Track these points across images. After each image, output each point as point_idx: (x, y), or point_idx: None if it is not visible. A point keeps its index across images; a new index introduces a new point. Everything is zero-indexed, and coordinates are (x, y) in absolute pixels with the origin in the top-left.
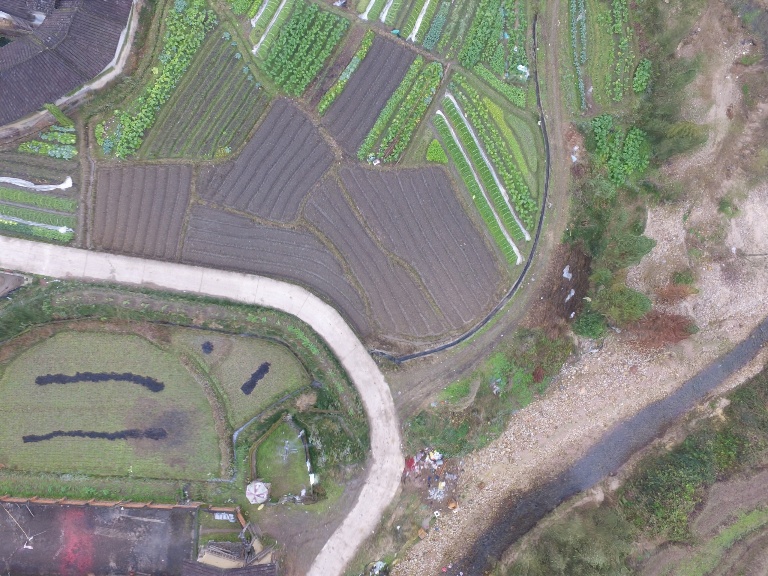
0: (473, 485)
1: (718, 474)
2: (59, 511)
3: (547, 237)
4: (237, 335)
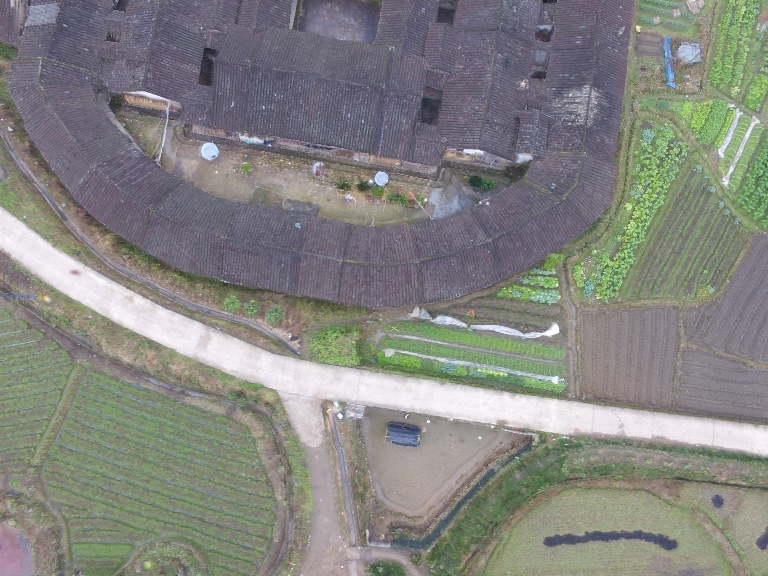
0: None
1: None
2: None
3: None
4: (752, 489)
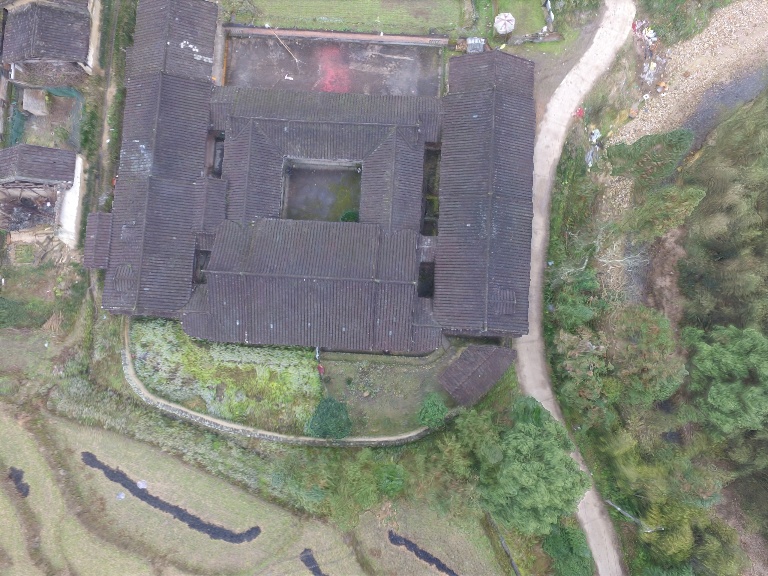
0: (678, 74)
1: None
2: (316, 49)
3: None
4: None
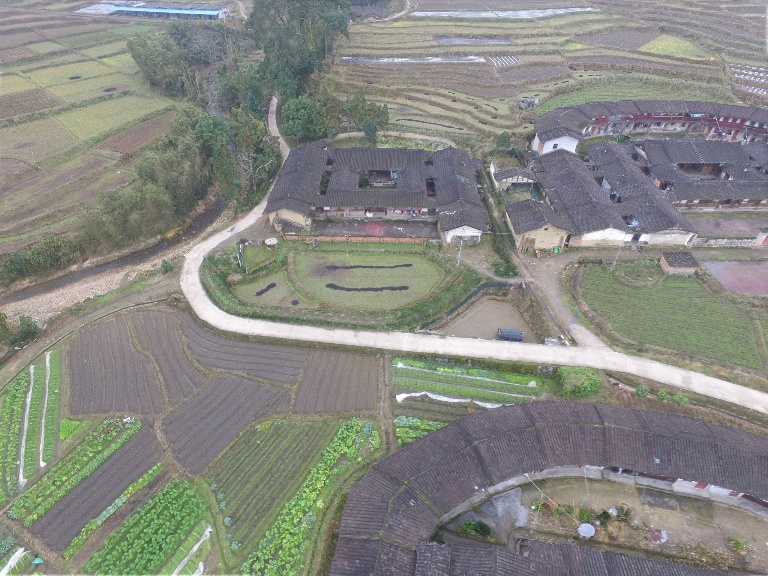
0: (159, 266)
1: (7, 257)
2: None
3: (16, 367)
4: None
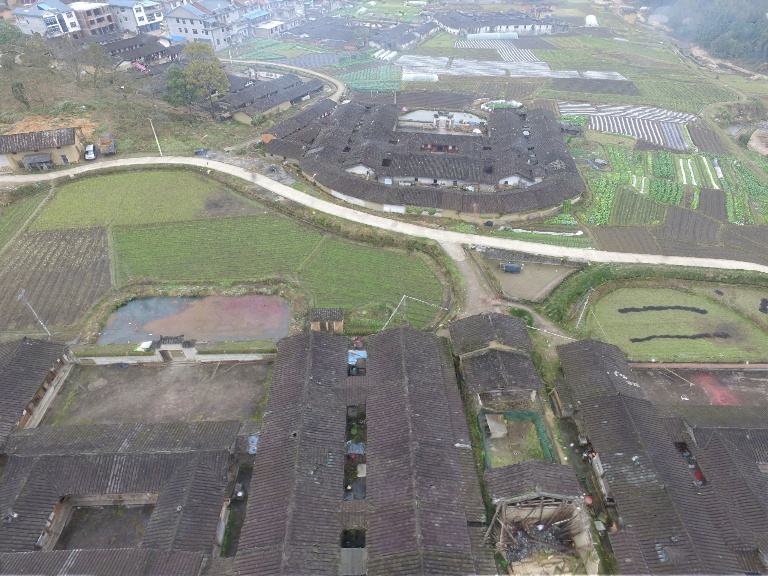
0: None
1: None
2: (691, 376)
3: None
4: (735, 284)
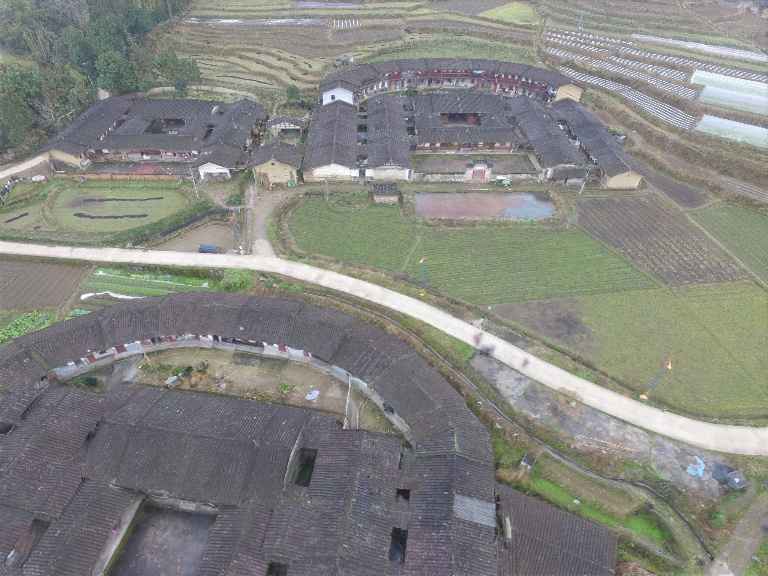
0: None
1: None
2: None
3: None
4: None
